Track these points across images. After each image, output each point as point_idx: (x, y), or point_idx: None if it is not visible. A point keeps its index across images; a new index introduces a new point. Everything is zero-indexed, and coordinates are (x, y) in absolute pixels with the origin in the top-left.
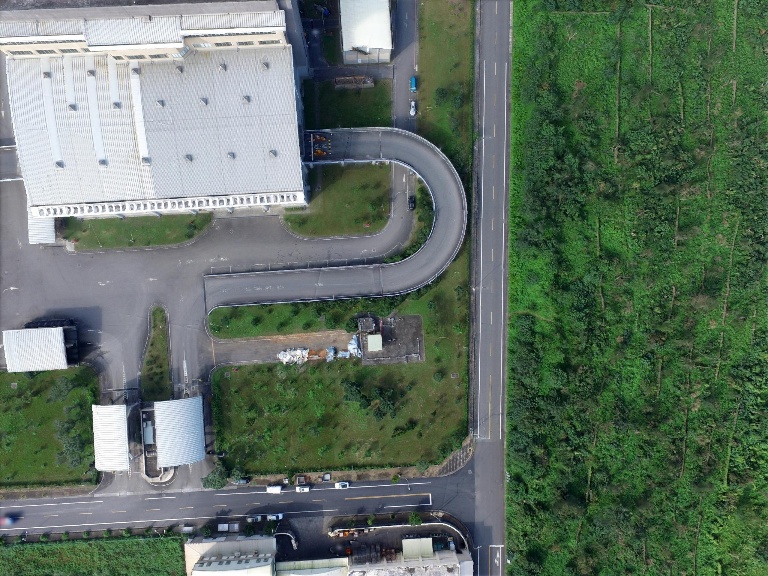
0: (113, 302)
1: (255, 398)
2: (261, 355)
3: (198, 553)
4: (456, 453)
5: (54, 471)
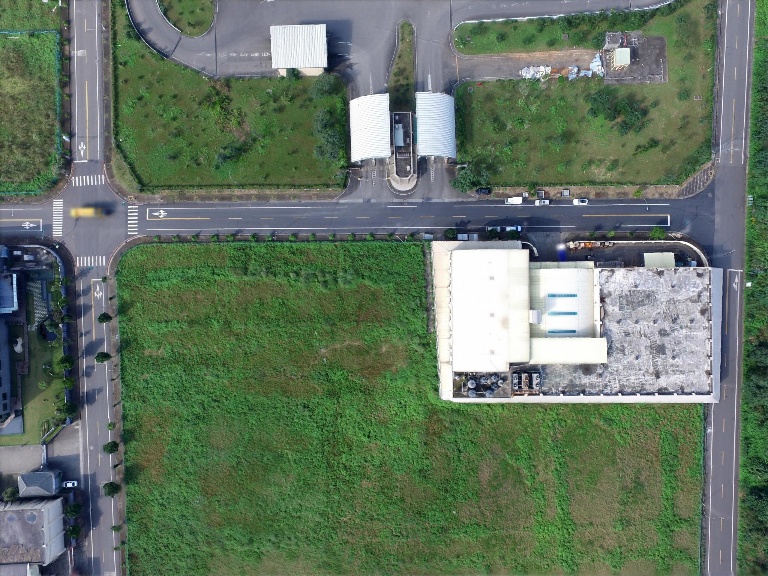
0: (363, 15)
1: (497, 112)
2: (504, 72)
3: (446, 250)
4: (696, 176)
5: (303, 175)
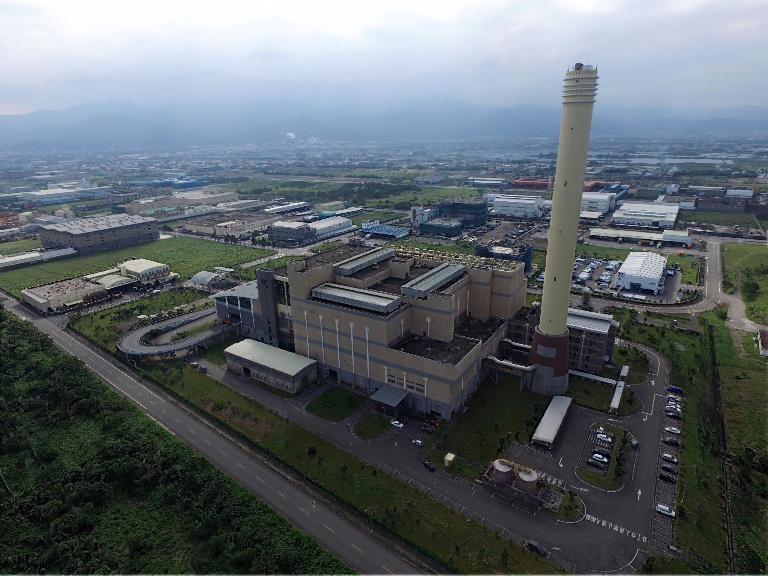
0: None
1: None
2: None
3: (172, 274)
4: None
5: None
